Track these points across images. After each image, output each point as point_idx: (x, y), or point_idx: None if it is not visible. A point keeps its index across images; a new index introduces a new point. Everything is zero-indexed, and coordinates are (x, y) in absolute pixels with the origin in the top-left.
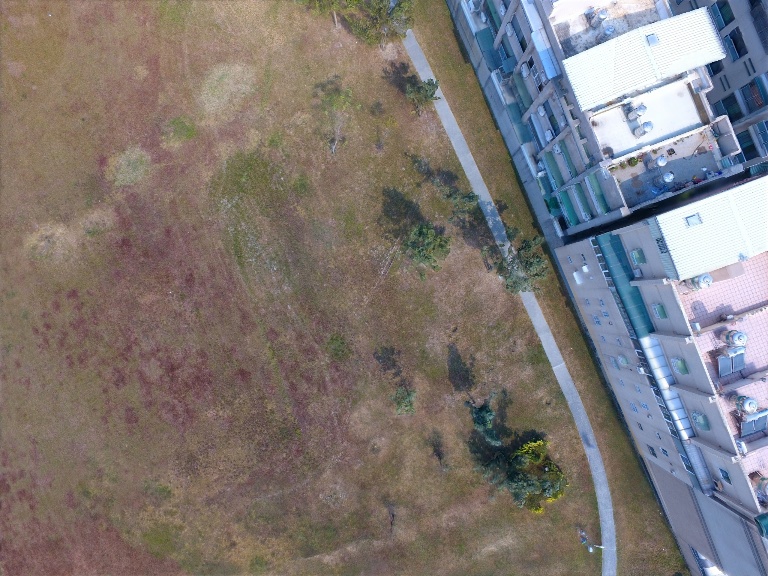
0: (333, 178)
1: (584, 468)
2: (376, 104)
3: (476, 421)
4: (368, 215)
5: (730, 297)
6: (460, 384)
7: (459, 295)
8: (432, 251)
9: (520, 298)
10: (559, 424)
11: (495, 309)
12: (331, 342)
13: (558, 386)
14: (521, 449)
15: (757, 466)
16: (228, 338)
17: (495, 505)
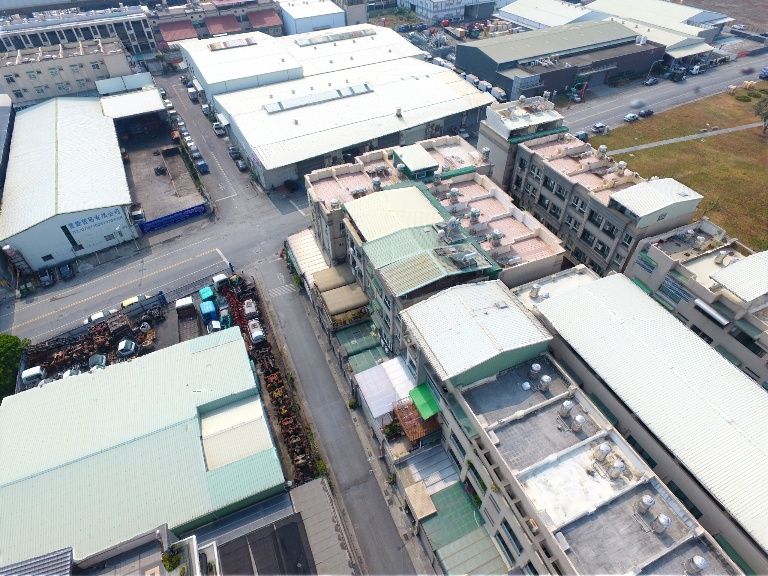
0: None
1: None
2: None
3: None
4: None
5: None
6: None
7: None
8: None
9: None
10: None
11: None
12: None
13: None
14: None
15: None
16: None
17: None
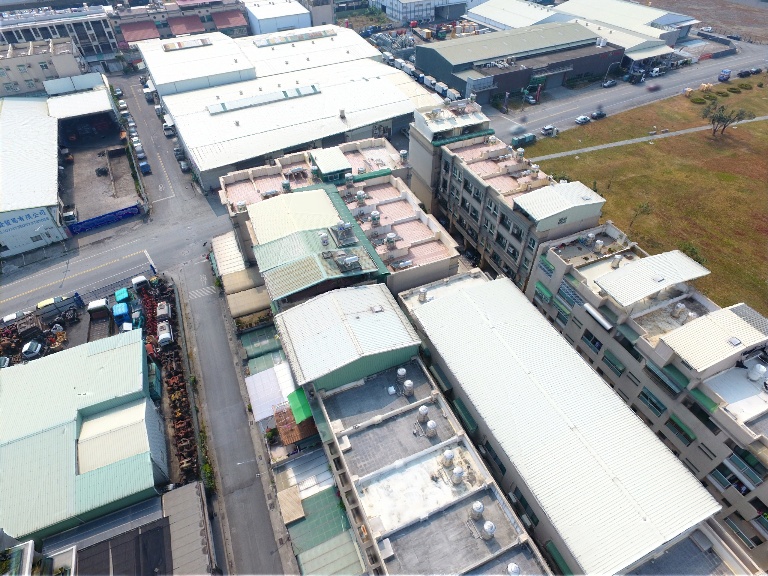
0: None
1: None
2: None
3: None
4: None
5: None
6: None
7: None
8: None
9: None
10: None
11: None
12: None
13: None
14: None
15: (499, 145)
16: (765, 248)
17: None
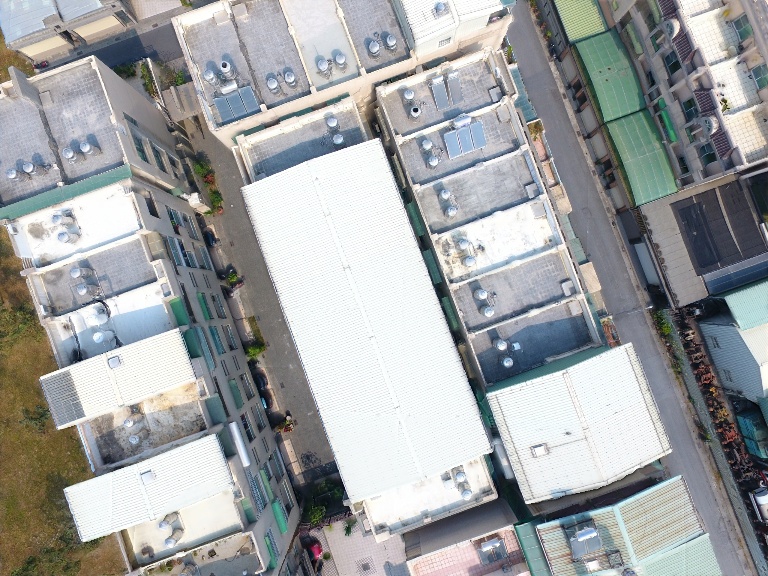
0: None
1: None
2: None
3: None
4: (31, 500)
5: None
6: None
7: None
8: None
9: None
10: None
11: None
12: None
13: None
14: None
15: None
16: None
17: None
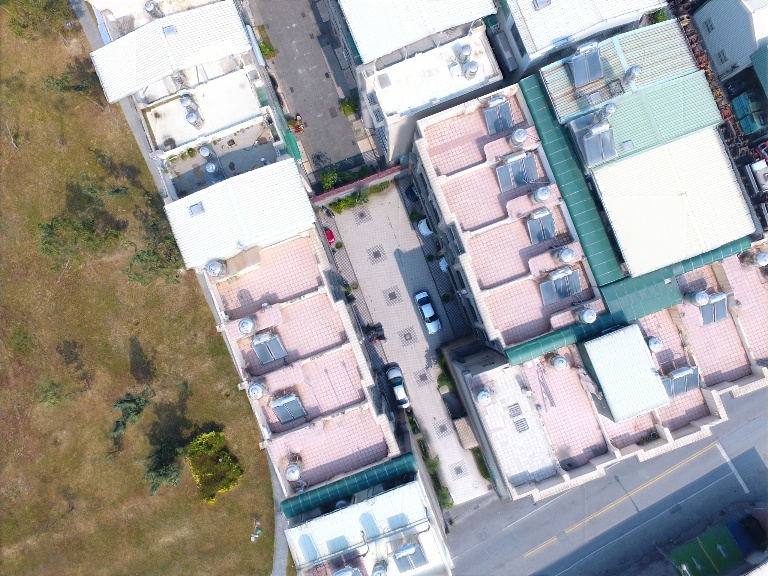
0: (17, 173)
1: (261, 459)
2: (60, 99)
3: (122, 413)
4: (52, 210)
5: (275, 285)
6: (142, 377)
7: (141, 288)
8: (73, 244)
9: (201, 291)
10: (238, 415)
11: (176, 302)
12: (14, 337)
13: (238, 378)
14: (194, 440)
15: (284, 451)
16: None
17: (173, 496)
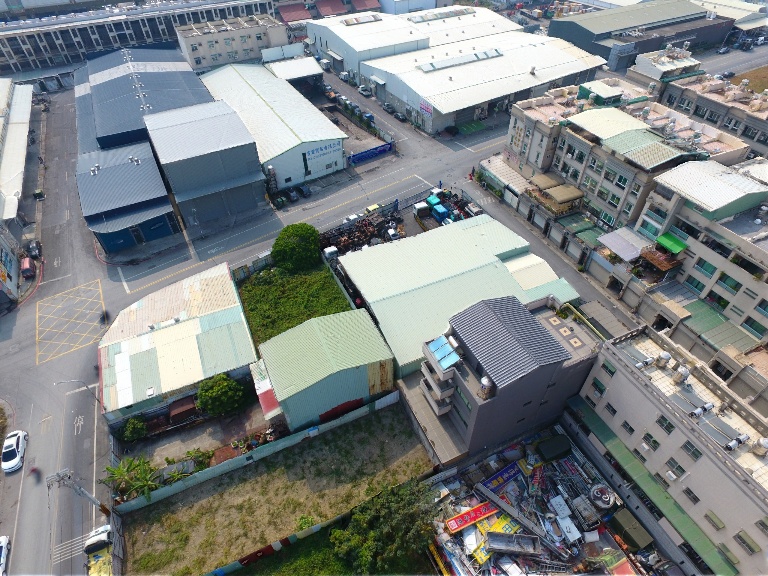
0: None
1: None
2: None
3: None
4: None
5: (762, 114)
6: None
7: None
8: None
9: None
10: None
11: None
12: None
13: None
14: None
15: None
16: None
17: None
